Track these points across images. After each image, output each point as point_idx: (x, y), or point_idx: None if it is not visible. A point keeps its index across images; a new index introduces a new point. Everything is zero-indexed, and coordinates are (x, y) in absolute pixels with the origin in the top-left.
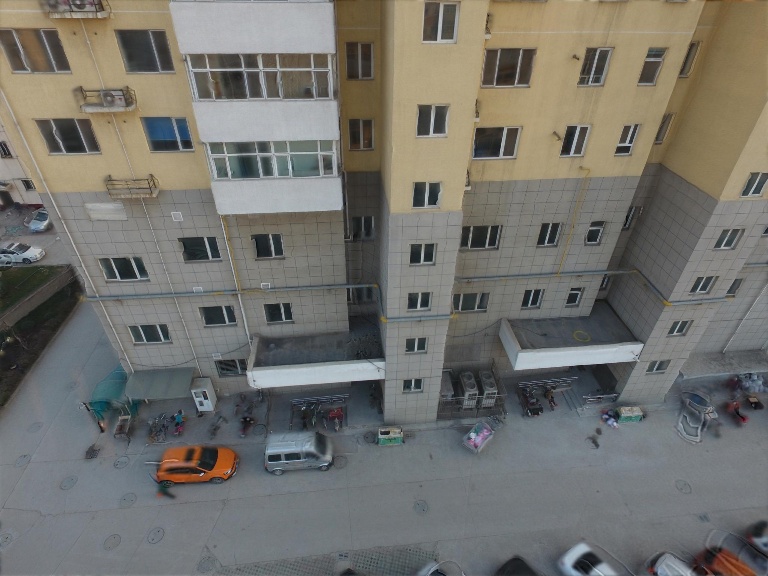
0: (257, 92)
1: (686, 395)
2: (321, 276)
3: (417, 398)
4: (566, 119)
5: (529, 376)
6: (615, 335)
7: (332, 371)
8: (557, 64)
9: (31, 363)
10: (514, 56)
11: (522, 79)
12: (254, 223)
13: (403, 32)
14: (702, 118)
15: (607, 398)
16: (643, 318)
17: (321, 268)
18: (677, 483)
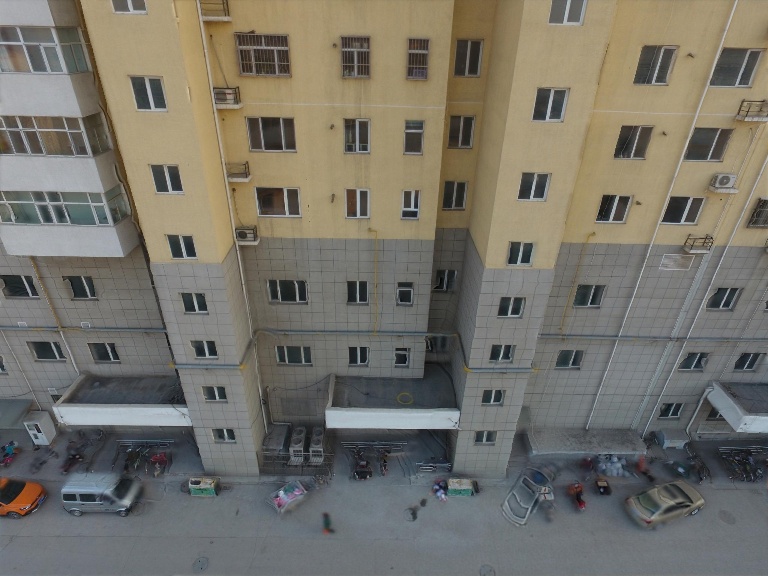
0: (23, 148)
1: (528, 472)
2: (137, 319)
3: (232, 449)
4: (342, 183)
5: (350, 436)
6: (440, 400)
7: (137, 413)
8: (318, 132)
9: None
10: (275, 124)
11: (289, 145)
12: (63, 265)
13: (116, 101)
14: (480, 187)
15: (440, 467)
16: (461, 384)
17: (136, 311)
18: (482, 568)
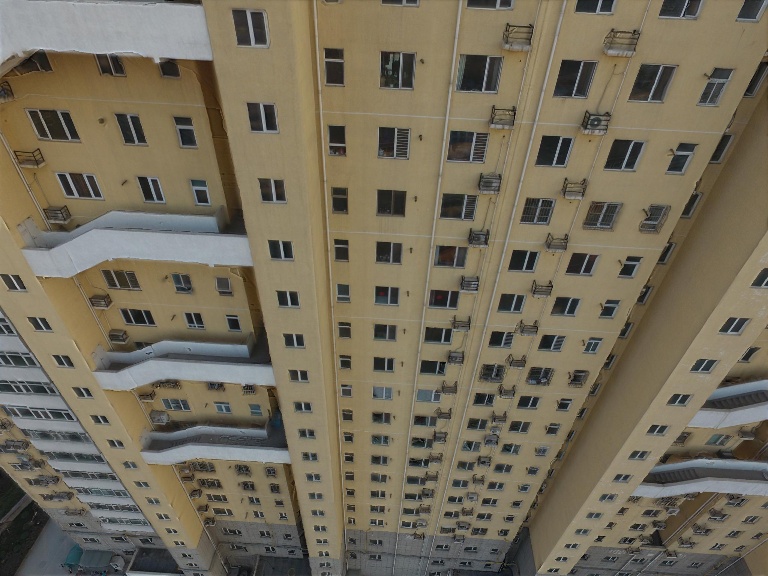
0: None
1: None
2: None
3: None
4: None
5: None
6: (308, 575)
7: None
8: (237, 499)
9: (47, 520)
10: None
11: None
12: None
13: (150, 518)
14: None
15: None
16: None
17: None
18: None
